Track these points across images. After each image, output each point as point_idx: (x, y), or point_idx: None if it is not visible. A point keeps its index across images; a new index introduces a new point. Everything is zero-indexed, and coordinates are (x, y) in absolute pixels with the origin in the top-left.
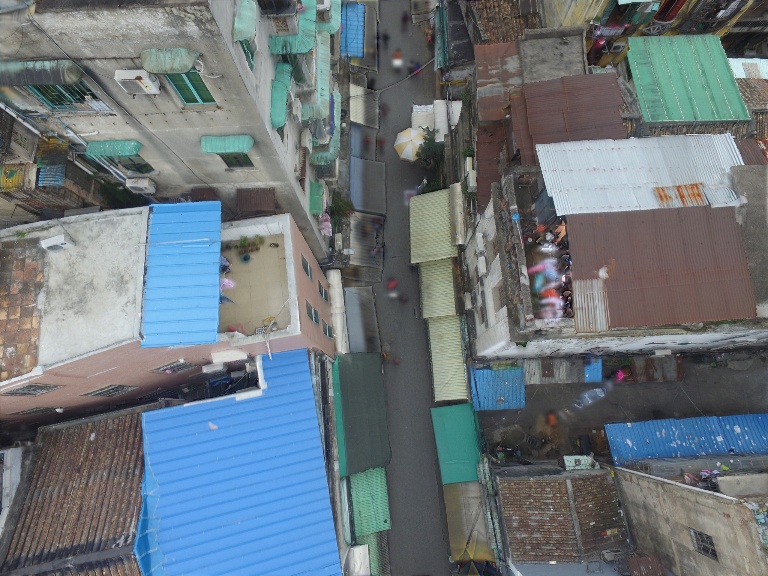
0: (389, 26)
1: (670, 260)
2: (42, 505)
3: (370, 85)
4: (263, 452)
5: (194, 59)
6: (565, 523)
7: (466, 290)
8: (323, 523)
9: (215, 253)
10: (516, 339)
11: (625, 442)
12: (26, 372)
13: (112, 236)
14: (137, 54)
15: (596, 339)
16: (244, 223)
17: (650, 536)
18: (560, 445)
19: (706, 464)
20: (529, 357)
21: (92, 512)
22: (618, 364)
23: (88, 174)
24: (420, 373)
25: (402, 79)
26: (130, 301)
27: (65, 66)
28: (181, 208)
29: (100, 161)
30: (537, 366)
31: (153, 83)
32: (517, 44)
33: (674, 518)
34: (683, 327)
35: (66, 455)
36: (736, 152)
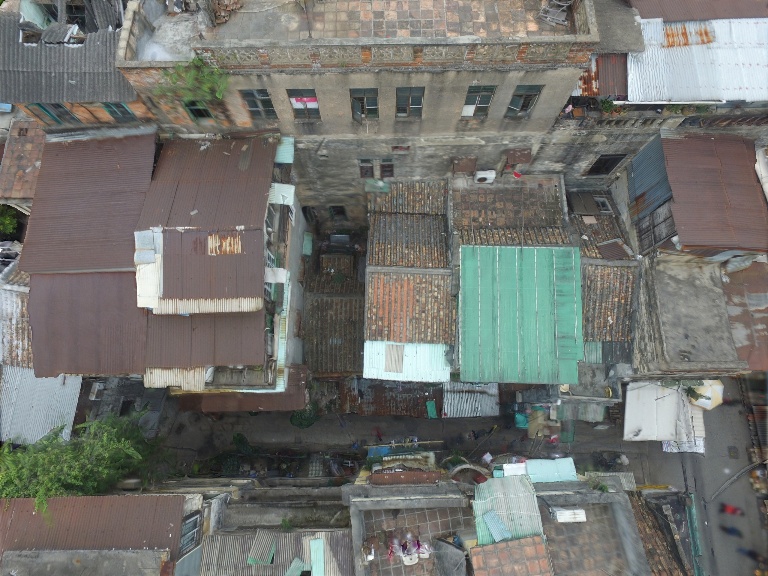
0: None
1: None
2: None
3: (744, 514)
4: None
5: None
6: None
7: None
8: None
9: None
10: None
11: None
12: None
13: None
14: None
15: None
16: None
17: None
18: None
19: None
20: None
21: None
22: None
23: None
24: None
25: None
26: None
27: None
28: None
29: None
30: None
31: None
32: None
33: None
34: None
35: None
36: None
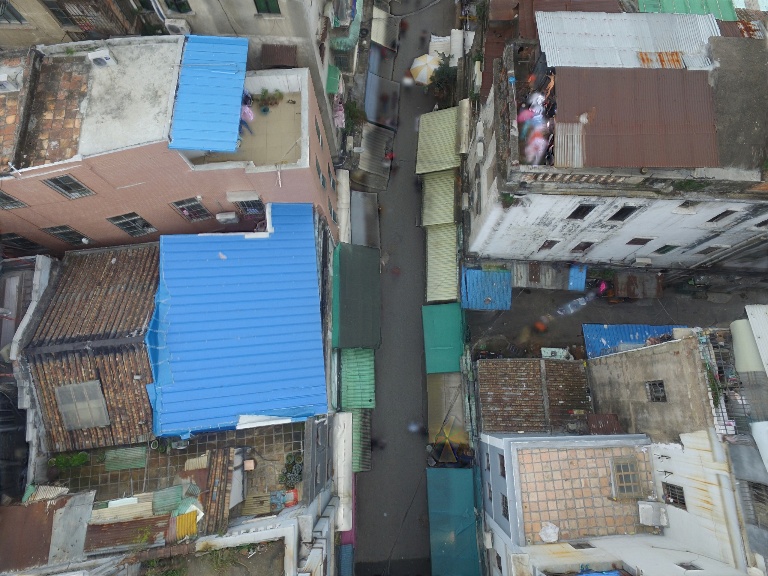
0: None
1: (645, 112)
2: (66, 305)
3: None
4: (265, 284)
5: None
6: (536, 398)
7: (464, 191)
8: (314, 351)
9: (240, 80)
10: (502, 189)
11: (600, 340)
12: None
13: (150, 59)
14: None
15: (578, 220)
16: (267, 73)
17: (612, 408)
18: None
19: None
20: (518, 259)
21: (110, 312)
22: (602, 278)
23: (133, 8)
24: (415, 282)
25: (423, 7)
26: (162, 112)
27: None
28: (213, 41)
29: None
30: (525, 270)
31: None
32: None
33: (633, 379)
34: (655, 190)
35: (89, 272)
36: (716, 27)
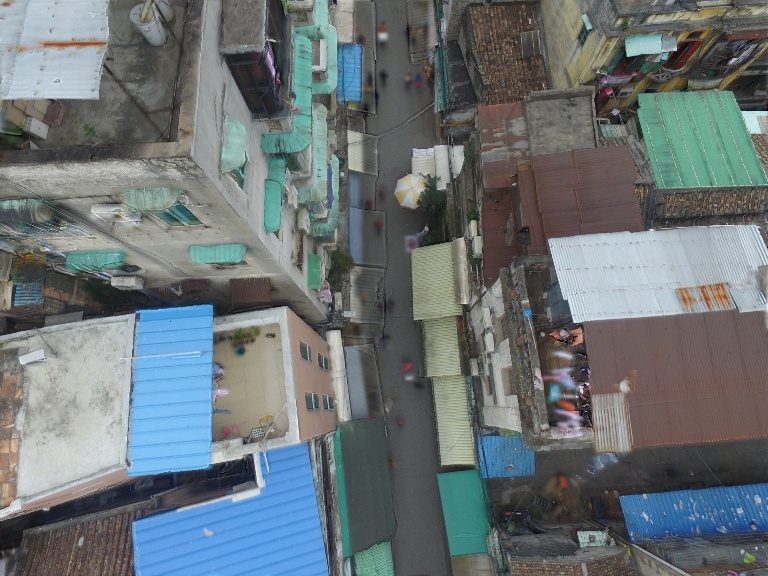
0: (387, 62)
1: (696, 371)
2: None
3: (368, 125)
4: (262, 558)
5: (178, 195)
6: None
7: (472, 355)
8: None
9: (207, 364)
10: (530, 444)
11: (641, 515)
12: (4, 503)
13: (96, 347)
14: (114, 195)
15: None
16: (238, 318)
17: None
18: (571, 507)
19: (729, 551)
20: None
21: None
22: None
23: (70, 275)
24: (425, 430)
25: (401, 124)
26: (116, 421)
27: (35, 206)
28: (170, 314)
29: (82, 268)
30: None
31: (134, 213)
32: (522, 105)
33: None
34: None
35: (53, 564)
36: (764, 248)
